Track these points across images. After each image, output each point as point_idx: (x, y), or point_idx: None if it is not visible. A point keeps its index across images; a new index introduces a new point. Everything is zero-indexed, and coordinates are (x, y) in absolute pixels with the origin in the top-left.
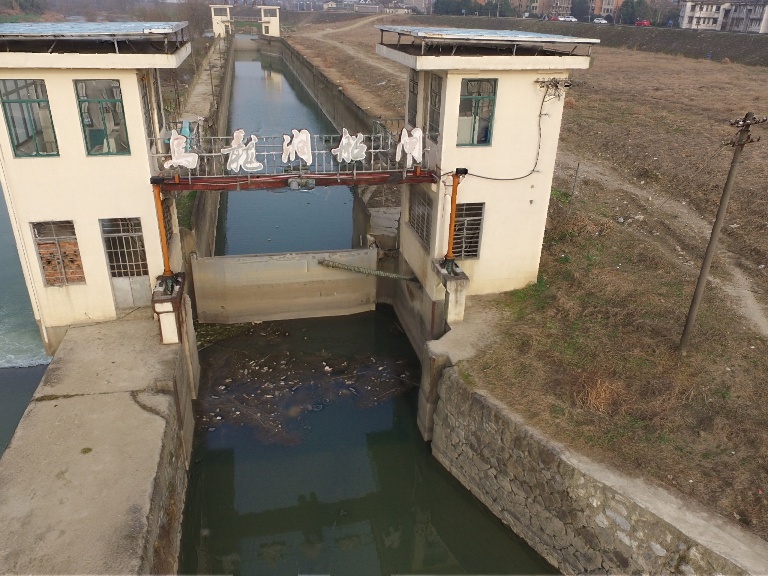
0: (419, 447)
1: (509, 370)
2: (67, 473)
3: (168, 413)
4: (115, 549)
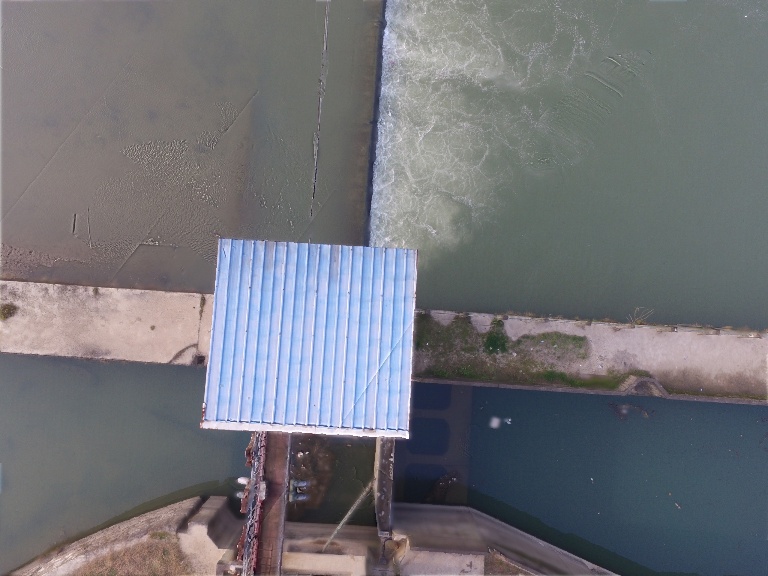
0: (215, 491)
1: (156, 564)
2: (139, 322)
3: None
4: (88, 347)
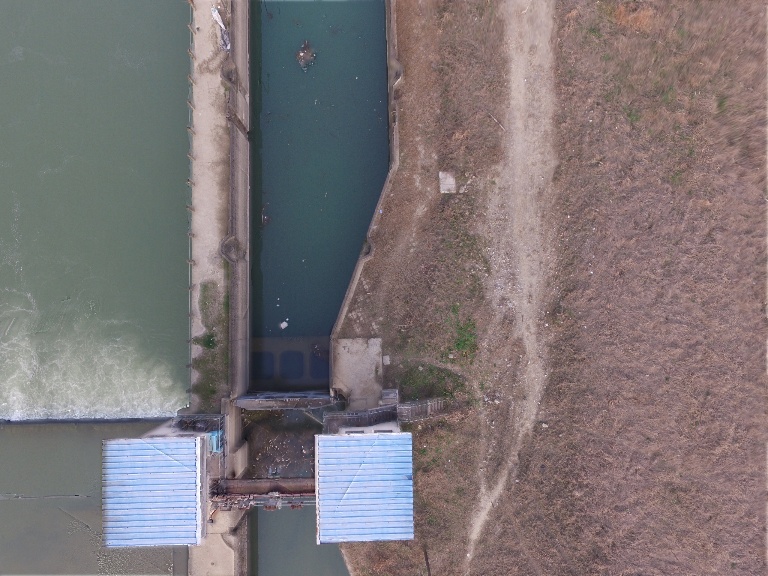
0: None
1: None
2: (209, 573)
3: (234, 546)
4: None
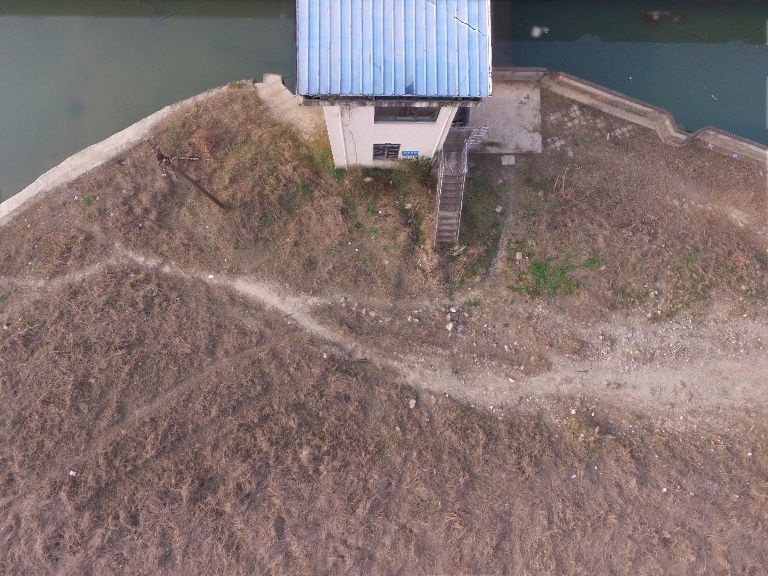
0: None
1: (238, 108)
2: None
3: None
4: None
